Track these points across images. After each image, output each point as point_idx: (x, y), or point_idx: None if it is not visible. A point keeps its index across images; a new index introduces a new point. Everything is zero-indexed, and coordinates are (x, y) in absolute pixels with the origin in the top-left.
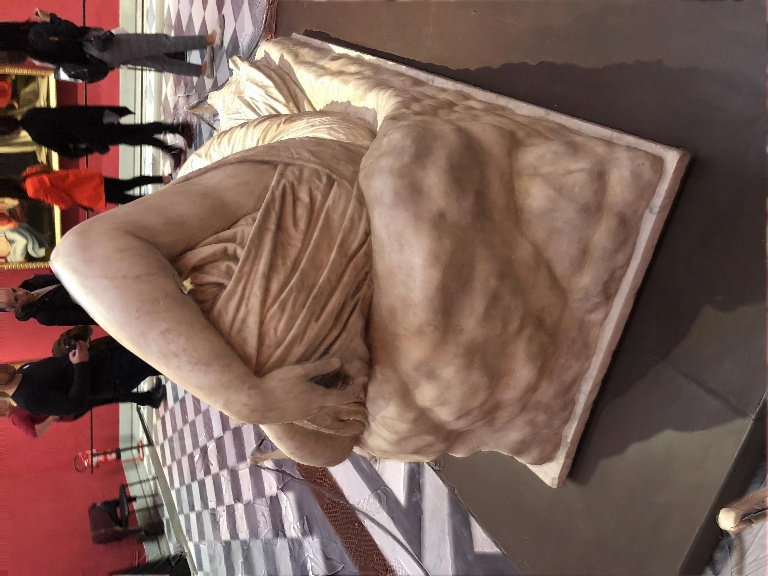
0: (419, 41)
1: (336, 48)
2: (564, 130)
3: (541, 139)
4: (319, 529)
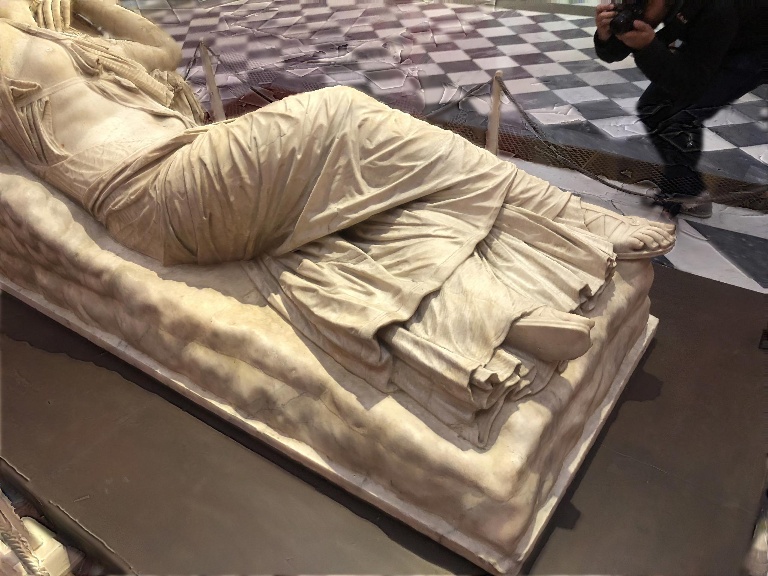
0: (154, 421)
1: (310, 455)
2: None
3: None
4: (584, 136)
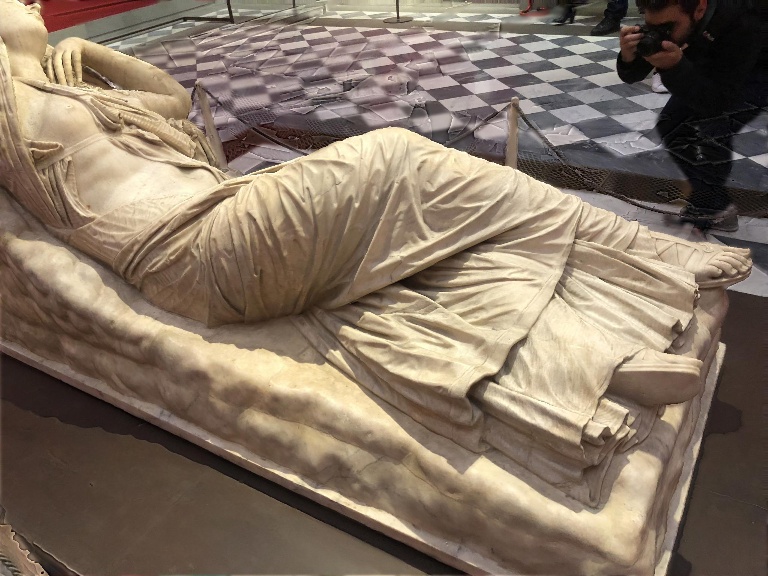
0: (210, 497)
1: (394, 524)
2: (15, 333)
3: (1, 302)
4: (593, 156)
